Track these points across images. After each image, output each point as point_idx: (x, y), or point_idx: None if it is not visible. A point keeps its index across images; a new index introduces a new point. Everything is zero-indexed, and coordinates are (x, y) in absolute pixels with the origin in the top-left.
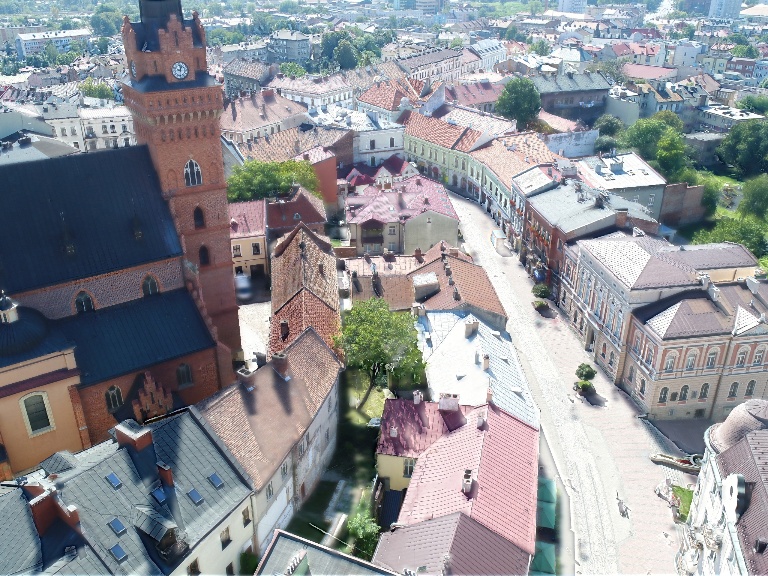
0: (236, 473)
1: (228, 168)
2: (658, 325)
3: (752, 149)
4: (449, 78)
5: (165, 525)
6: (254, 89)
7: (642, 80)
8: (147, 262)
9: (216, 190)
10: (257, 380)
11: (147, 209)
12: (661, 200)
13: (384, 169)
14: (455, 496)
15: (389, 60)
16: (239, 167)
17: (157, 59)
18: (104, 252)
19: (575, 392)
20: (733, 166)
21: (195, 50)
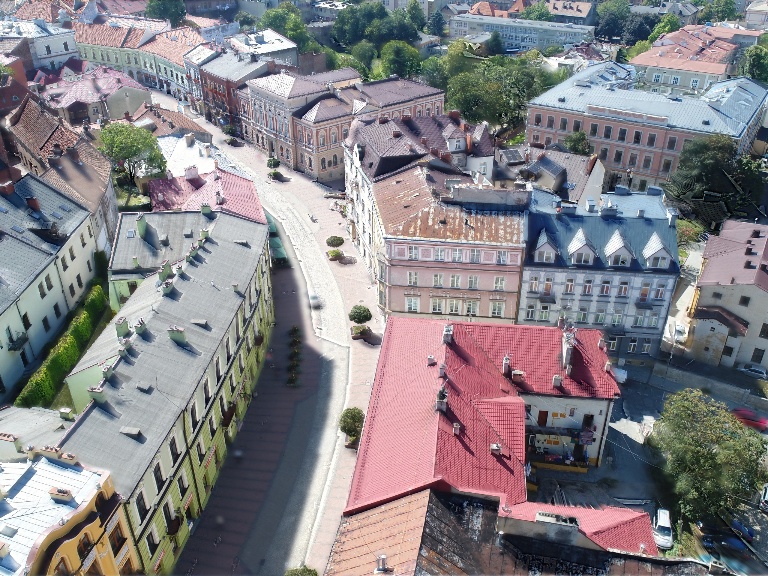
0: (76, 204)
1: None
2: (309, 117)
3: (354, 28)
4: None
5: (49, 222)
6: None
7: None
8: None
9: None
10: (62, 164)
11: None
12: (297, 60)
13: (67, 68)
14: (214, 208)
15: None
16: None
17: None
18: None
19: (270, 179)
20: (346, 46)
21: None
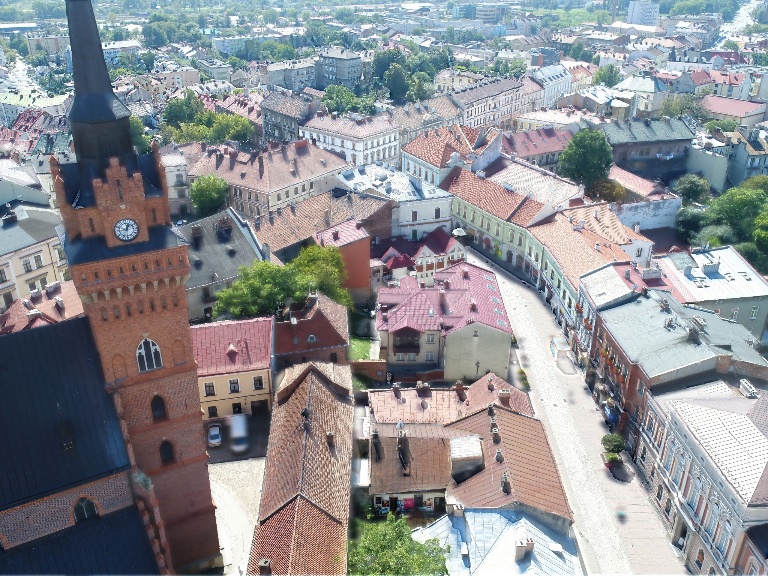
0: None
1: (239, 258)
2: None
3: None
4: (507, 111)
5: None
6: (292, 127)
7: (727, 121)
8: (78, 484)
9: (182, 373)
10: None
11: (83, 407)
12: (766, 313)
13: (426, 248)
14: None
15: (442, 88)
16: (247, 269)
17: (94, 216)
18: (17, 474)
19: None
20: None
21: (149, 200)
